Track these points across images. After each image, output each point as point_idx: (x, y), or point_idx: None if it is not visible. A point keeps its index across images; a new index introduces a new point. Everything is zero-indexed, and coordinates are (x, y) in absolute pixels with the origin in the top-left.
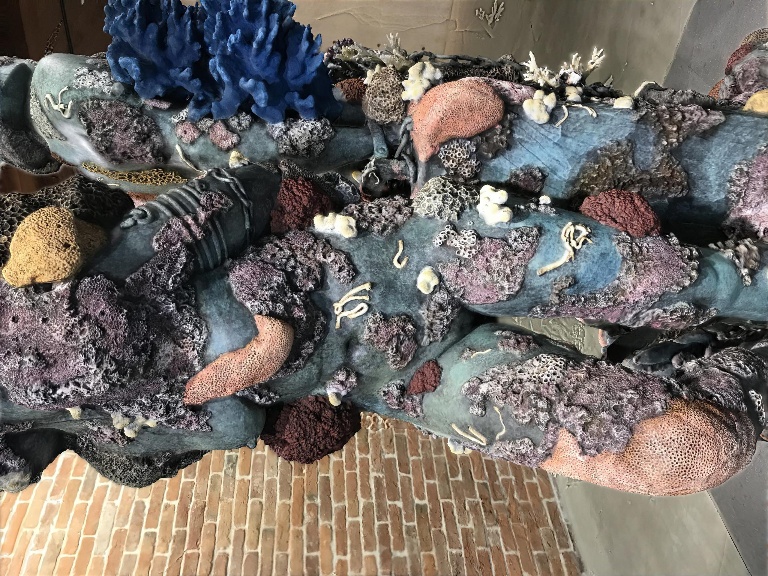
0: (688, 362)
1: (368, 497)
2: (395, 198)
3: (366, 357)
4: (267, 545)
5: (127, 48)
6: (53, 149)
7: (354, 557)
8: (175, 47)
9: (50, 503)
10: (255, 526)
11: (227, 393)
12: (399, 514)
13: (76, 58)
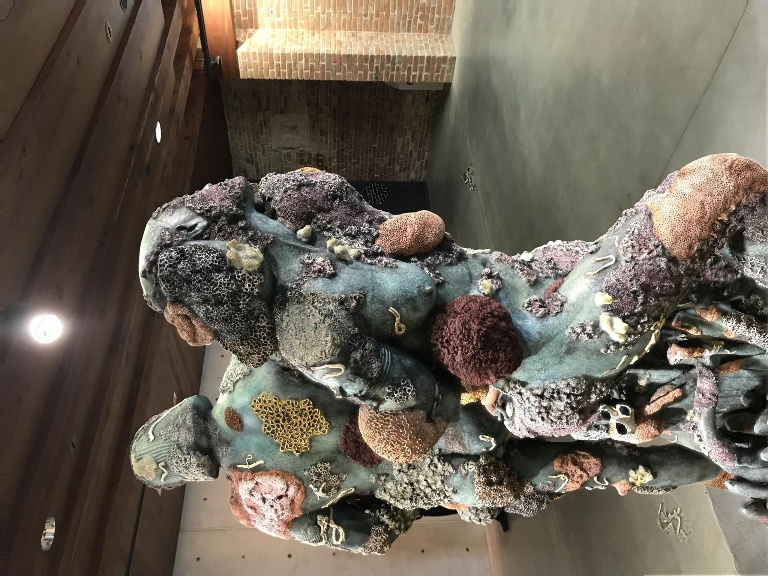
0: None
1: None
2: None
3: (501, 268)
4: None
5: None
6: (229, 404)
7: None
8: None
9: None
10: None
11: (407, 236)
12: None
13: None
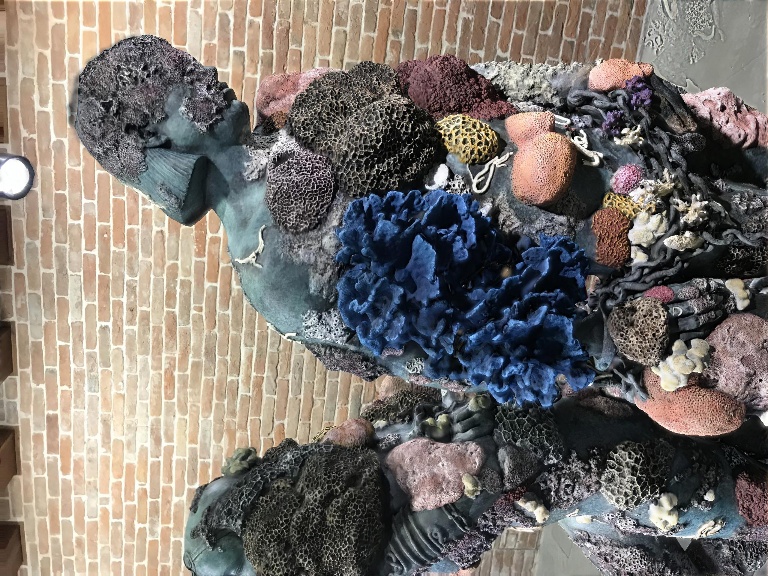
0: (728, 549)
1: (452, 41)
2: (591, 464)
3: None
4: None
5: None
6: None
7: None
8: None
9: (132, 3)
10: (339, 58)
11: None
12: None
13: (297, 285)
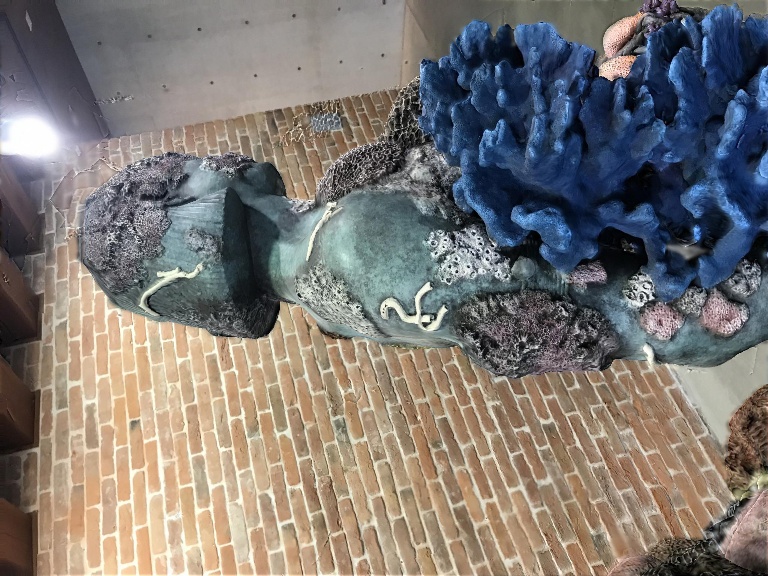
0: None
1: (493, 430)
2: None
3: None
4: (410, 507)
5: (498, 175)
6: (331, 329)
7: (501, 497)
8: (610, 167)
9: (170, 521)
10: (390, 490)
11: None
12: (529, 440)
13: (399, 208)
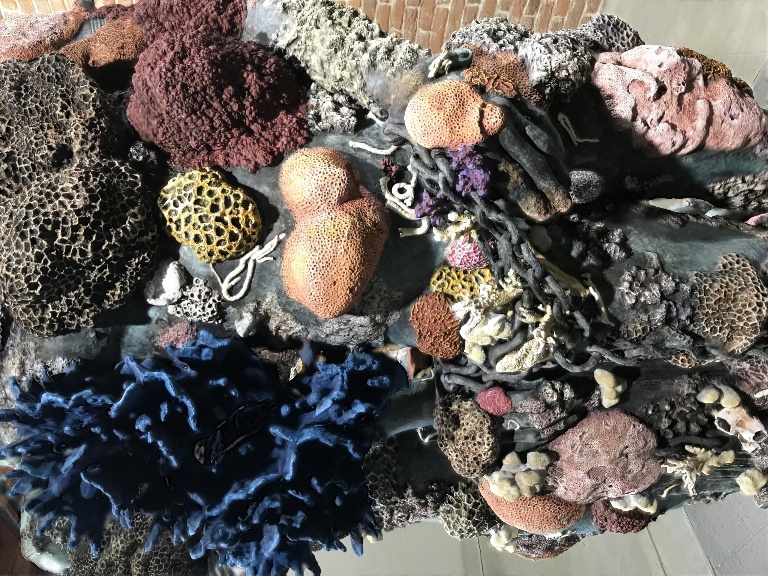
0: None
1: None
2: None
3: None
4: None
5: None
6: None
7: None
8: None
9: None
10: None
11: None
12: None
13: None
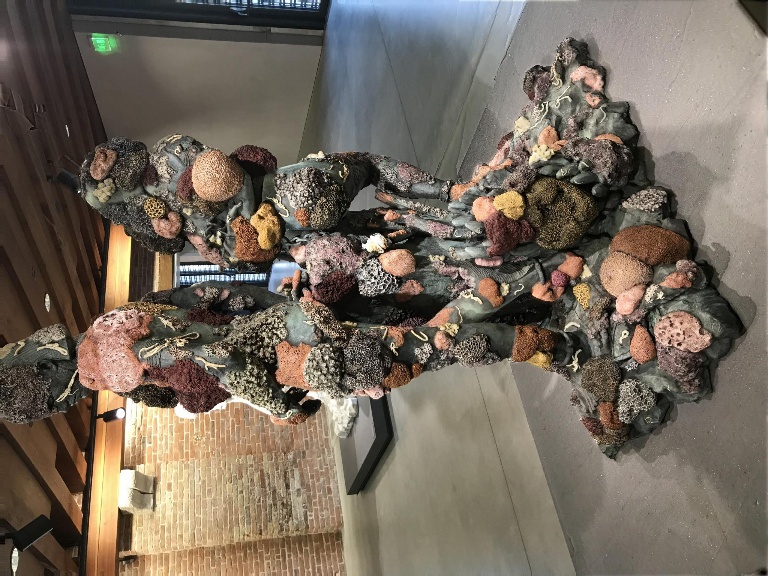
0: None
1: None
2: None
3: None
4: None
5: None
6: None
7: None
8: None
9: None
10: None
11: None
12: None
13: None
